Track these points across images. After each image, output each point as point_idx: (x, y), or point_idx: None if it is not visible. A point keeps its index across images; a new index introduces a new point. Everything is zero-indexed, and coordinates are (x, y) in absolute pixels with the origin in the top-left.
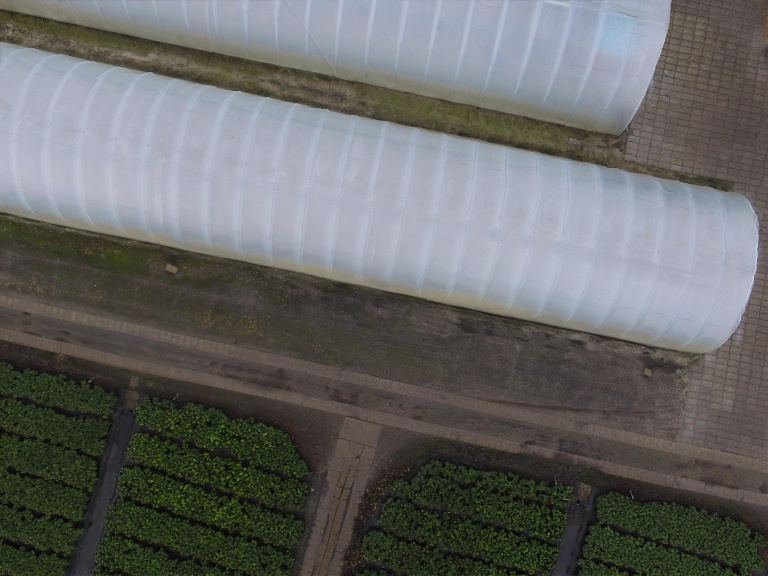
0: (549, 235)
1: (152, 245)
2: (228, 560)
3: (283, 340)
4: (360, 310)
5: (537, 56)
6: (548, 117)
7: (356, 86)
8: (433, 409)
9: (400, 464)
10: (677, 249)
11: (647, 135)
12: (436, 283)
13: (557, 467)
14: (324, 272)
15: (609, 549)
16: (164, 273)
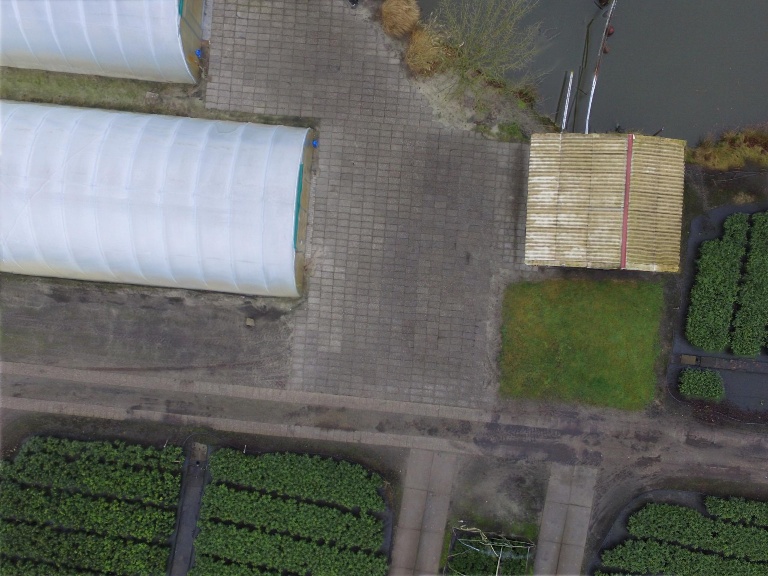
0: (77, 190)
1: None
2: None
3: None
4: None
5: (58, 9)
6: (116, 73)
7: None
8: (32, 384)
9: (4, 444)
10: (212, 189)
11: (226, 80)
12: None
13: (167, 429)
14: None
15: (224, 507)
16: None
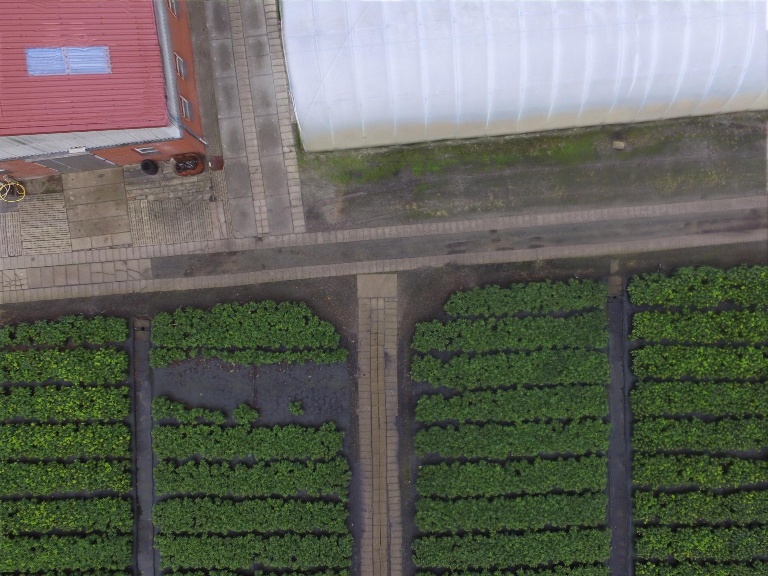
0: None
1: (592, 128)
2: (764, 406)
3: (746, 181)
4: None
5: None
6: None
7: None
8: None
9: None
10: None
11: None
12: None
13: None
14: None
15: None
16: (612, 152)
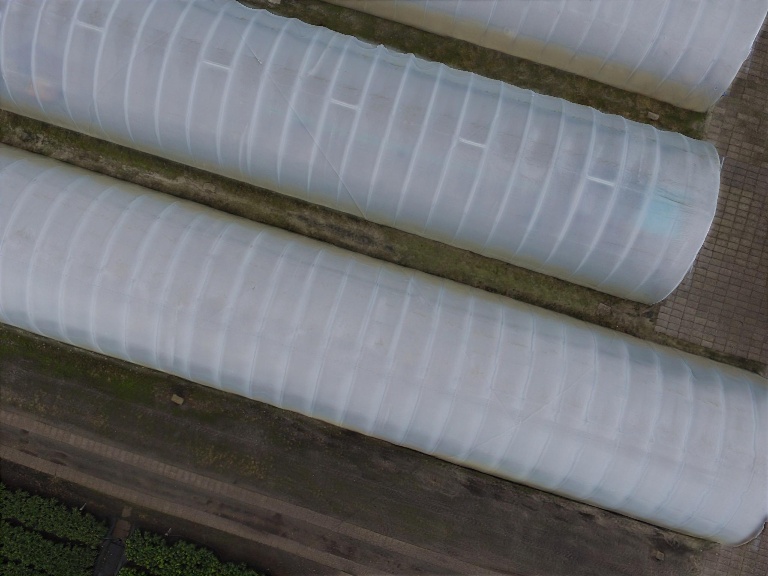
0: (571, 422)
1: (160, 373)
2: None
3: (284, 485)
4: (367, 461)
5: (575, 231)
6: (579, 281)
7: (385, 229)
8: (432, 572)
9: None
10: (704, 449)
11: (680, 307)
12: (448, 451)
13: None
14: (333, 423)
15: None
16: (169, 403)
